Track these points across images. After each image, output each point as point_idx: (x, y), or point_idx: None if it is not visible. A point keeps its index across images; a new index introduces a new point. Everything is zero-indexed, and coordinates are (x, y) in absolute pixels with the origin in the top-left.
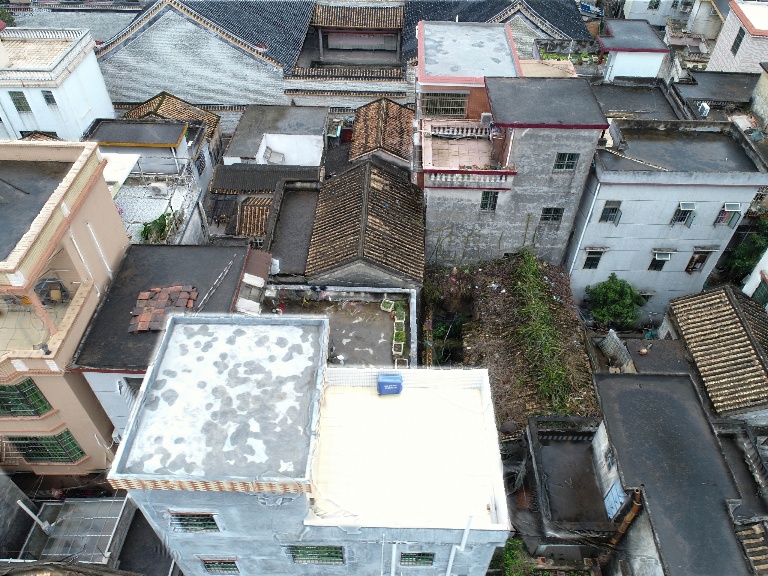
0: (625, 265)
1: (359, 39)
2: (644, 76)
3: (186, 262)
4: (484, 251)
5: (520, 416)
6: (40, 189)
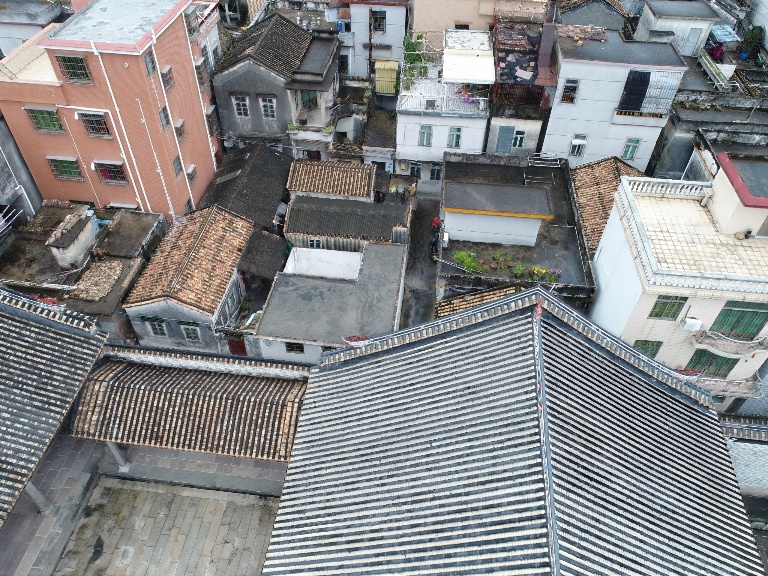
0: None
1: None
2: None
3: None
4: None
5: None
6: None
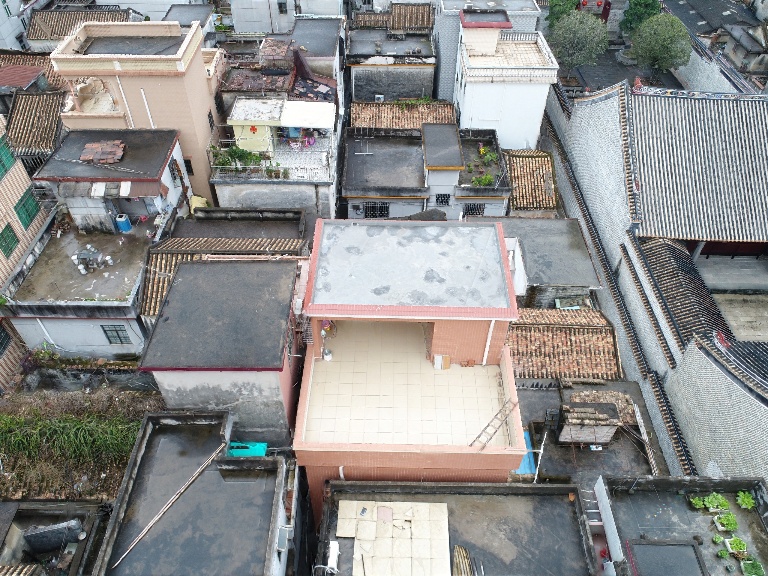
0: None
1: None
2: None
3: (150, 154)
4: None
5: (5, 411)
6: None
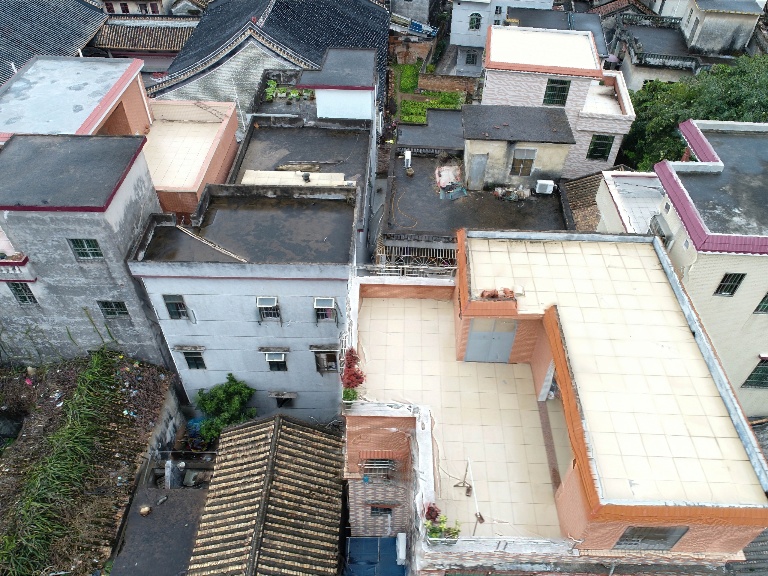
0: (239, 365)
1: (163, 61)
2: (357, 117)
3: None
4: (61, 348)
5: None
6: None
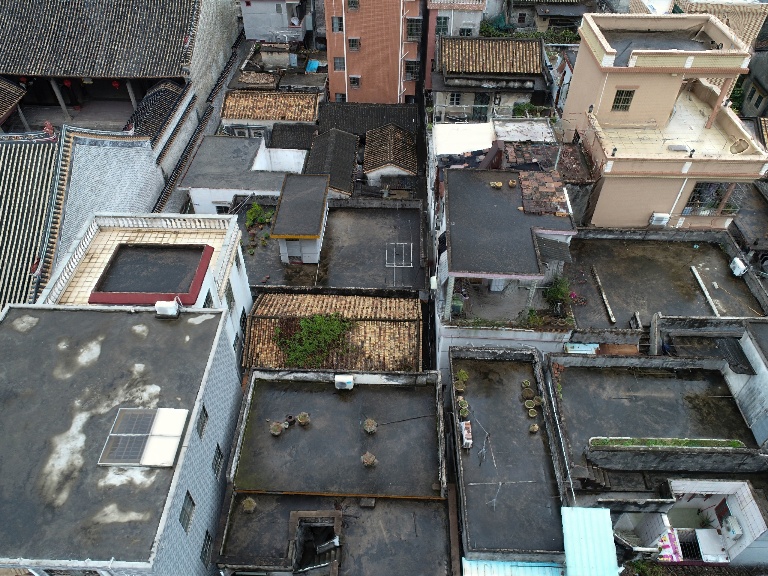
0: None
1: None
2: None
3: None
4: None
5: None
6: (624, 39)
